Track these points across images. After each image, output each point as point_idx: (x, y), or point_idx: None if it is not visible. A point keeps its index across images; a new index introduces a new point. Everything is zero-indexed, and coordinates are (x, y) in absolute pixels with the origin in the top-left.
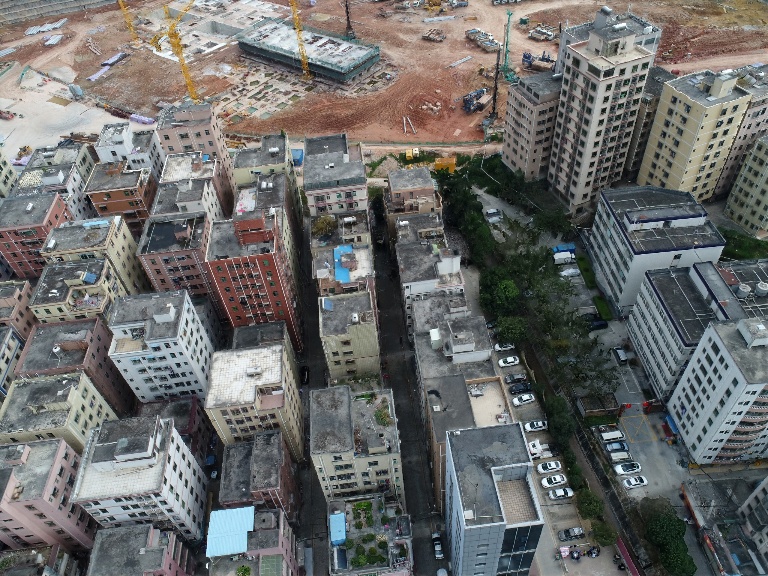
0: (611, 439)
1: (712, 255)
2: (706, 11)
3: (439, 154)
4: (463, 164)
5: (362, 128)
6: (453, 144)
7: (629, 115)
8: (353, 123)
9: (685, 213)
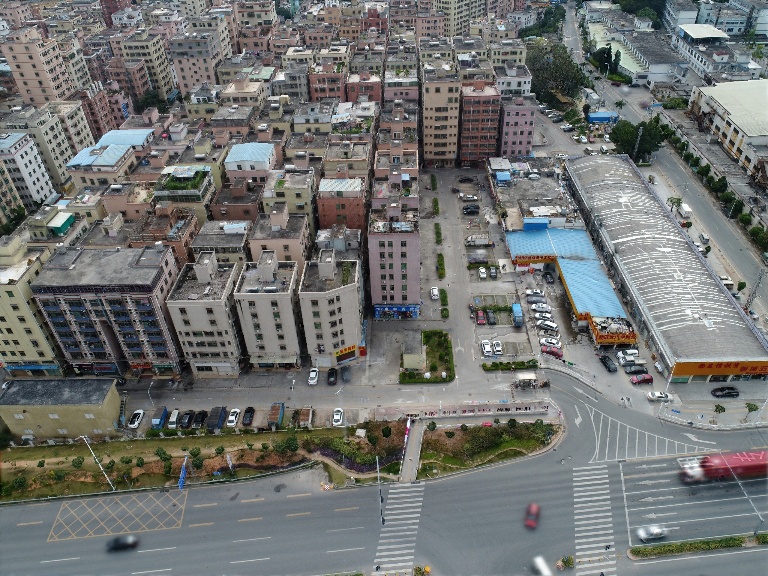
0: None
1: None
2: (32, 6)
3: None
4: None
5: None
6: None
7: None
8: None
9: None
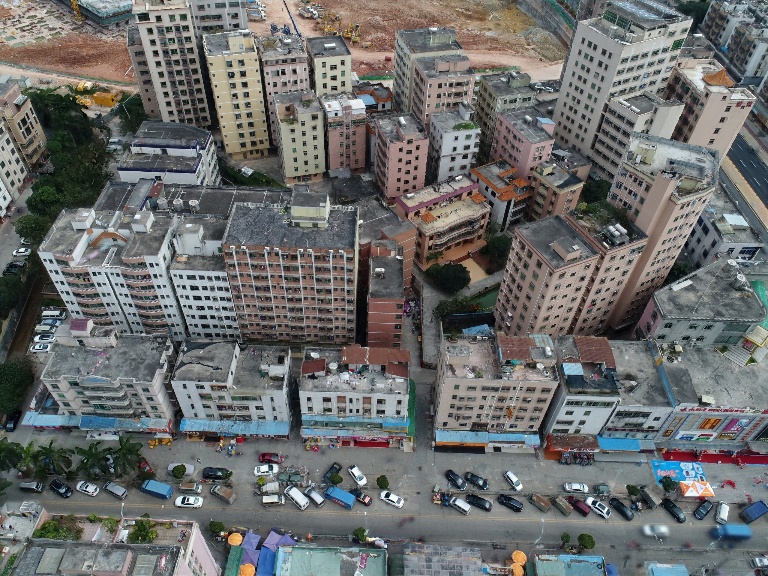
0: (49, 316)
1: (189, 181)
2: (472, 16)
3: (108, 90)
4: (123, 101)
5: (91, 66)
6: (126, 84)
7: (189, 62)
8: (87, 61)
9: (178, 144)
